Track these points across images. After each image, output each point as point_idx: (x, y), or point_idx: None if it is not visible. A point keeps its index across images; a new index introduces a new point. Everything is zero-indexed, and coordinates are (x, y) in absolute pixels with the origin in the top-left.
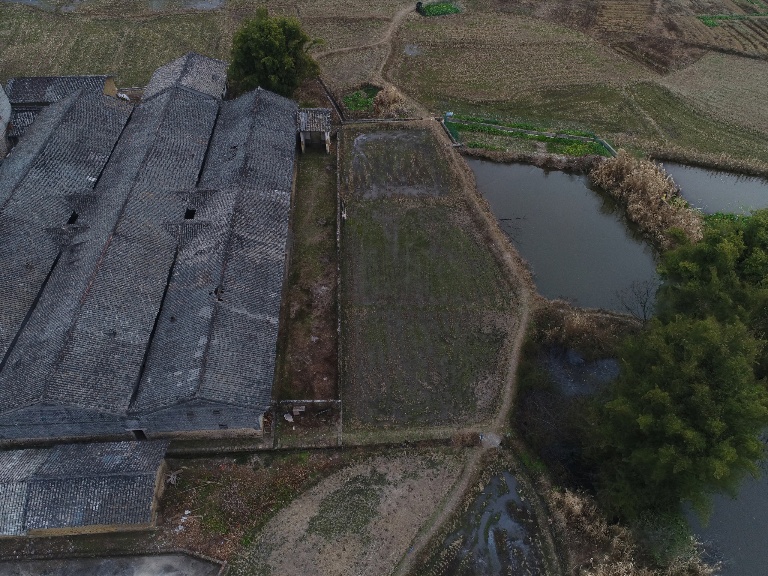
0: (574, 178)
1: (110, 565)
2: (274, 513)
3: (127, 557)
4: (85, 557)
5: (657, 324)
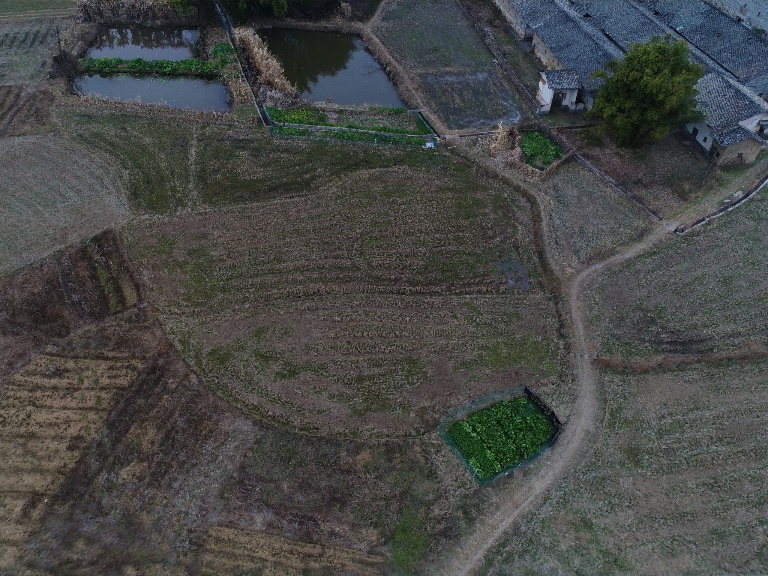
0: None
1: None
2: None
3: None
4: None
5: None
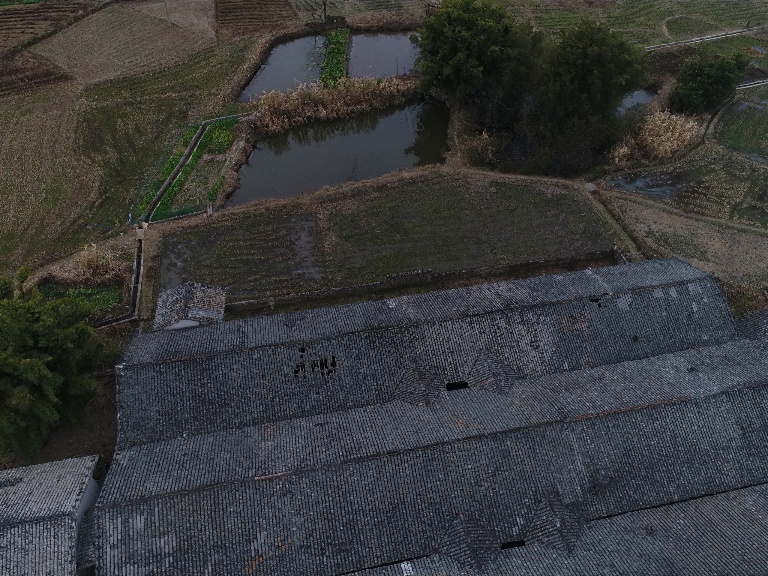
0: (259, 148)
1: None
2: None
3: None
4: None
5: (547, 66)
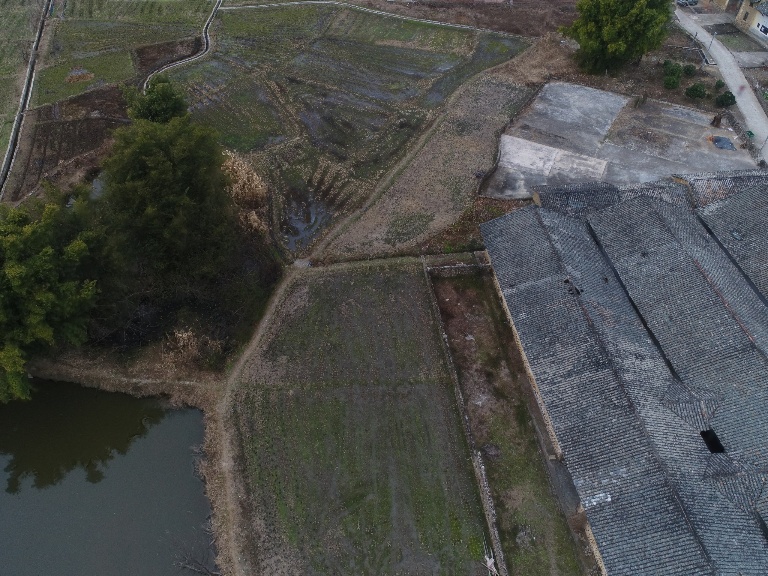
0: None
1: None
2: None
3: None
4: None
5: None
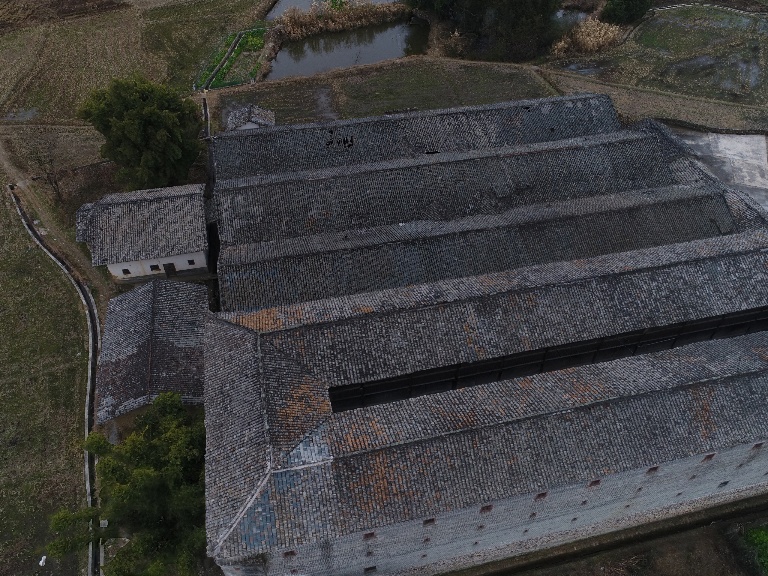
0: (283, 50)
1: None
2: None
3: None
4: None
5: None
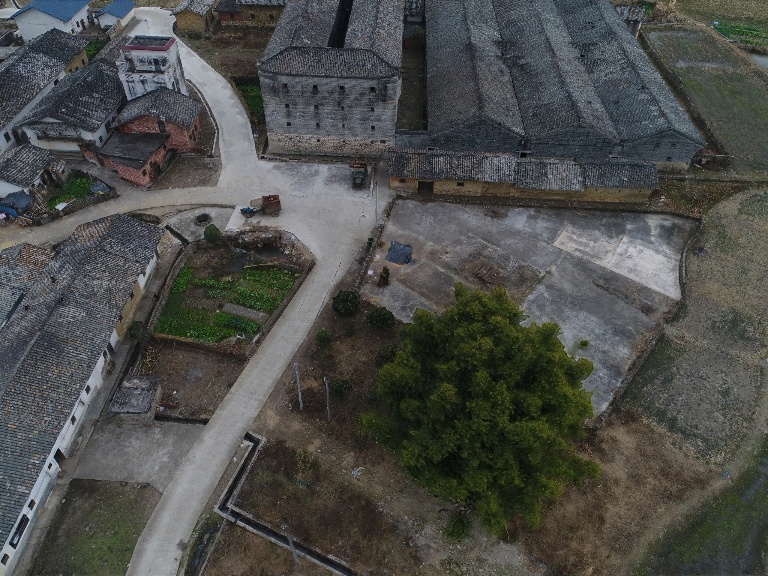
0: None
1: (629, 215)
2: (713, 205)
3: (637, 213)
4: (612, 210)
5: None
